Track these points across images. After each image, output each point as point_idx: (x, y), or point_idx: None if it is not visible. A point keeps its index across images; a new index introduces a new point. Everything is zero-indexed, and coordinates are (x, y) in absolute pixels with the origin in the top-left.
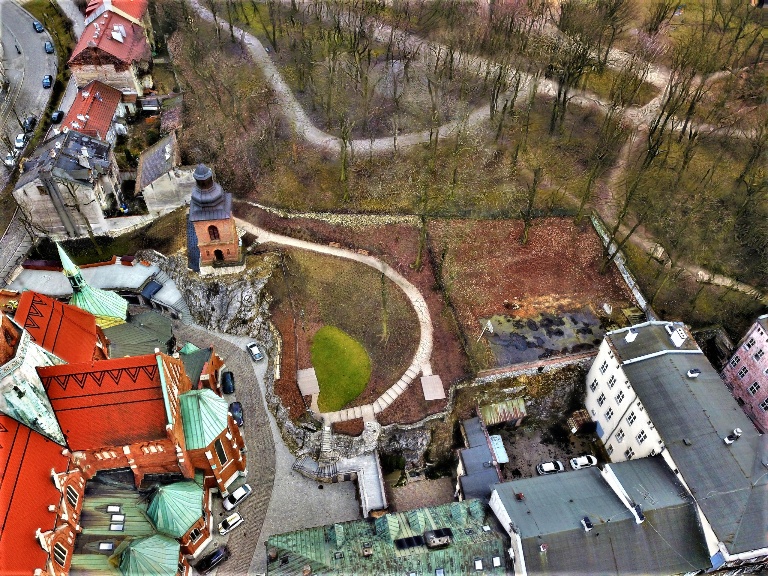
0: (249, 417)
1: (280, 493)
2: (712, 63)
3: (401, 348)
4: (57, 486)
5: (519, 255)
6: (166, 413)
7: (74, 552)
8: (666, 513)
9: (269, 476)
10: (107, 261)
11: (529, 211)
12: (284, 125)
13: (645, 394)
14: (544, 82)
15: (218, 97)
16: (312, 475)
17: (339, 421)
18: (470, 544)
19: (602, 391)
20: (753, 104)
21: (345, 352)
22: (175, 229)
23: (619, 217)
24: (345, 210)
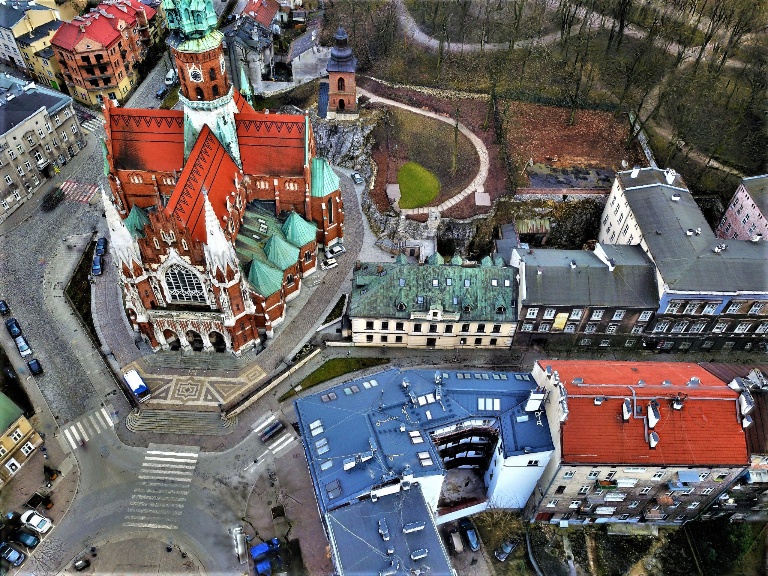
0: (348, 213)
1: (364, 256)
2: (748, 2)
3: (464, 177)
4: (236, 186)
5: (565, 131)
6: (305, 158)
7: (238, 233)
8: (632, 269)
9: (358, 246)
10: (259, 111)
11: (576, 94)
12: (399, 30)
13: (636, 207)
14: (613, 21)
15: (353, 5)
16: (388, 247)
17: (412, 214)
18: (491, 268)
19: (610, 221)
20: (766, 23)
21: (423, 178)
22: (311, 92)
23: (653, 117)
24: (437, 86)
